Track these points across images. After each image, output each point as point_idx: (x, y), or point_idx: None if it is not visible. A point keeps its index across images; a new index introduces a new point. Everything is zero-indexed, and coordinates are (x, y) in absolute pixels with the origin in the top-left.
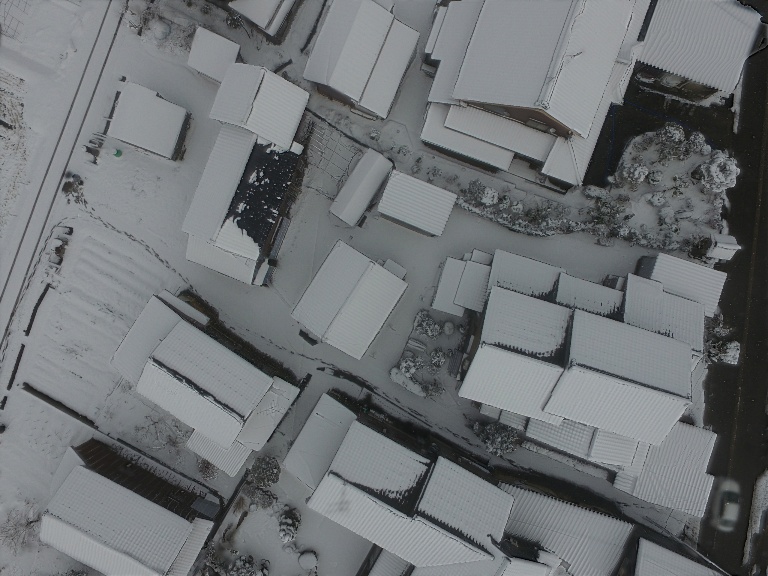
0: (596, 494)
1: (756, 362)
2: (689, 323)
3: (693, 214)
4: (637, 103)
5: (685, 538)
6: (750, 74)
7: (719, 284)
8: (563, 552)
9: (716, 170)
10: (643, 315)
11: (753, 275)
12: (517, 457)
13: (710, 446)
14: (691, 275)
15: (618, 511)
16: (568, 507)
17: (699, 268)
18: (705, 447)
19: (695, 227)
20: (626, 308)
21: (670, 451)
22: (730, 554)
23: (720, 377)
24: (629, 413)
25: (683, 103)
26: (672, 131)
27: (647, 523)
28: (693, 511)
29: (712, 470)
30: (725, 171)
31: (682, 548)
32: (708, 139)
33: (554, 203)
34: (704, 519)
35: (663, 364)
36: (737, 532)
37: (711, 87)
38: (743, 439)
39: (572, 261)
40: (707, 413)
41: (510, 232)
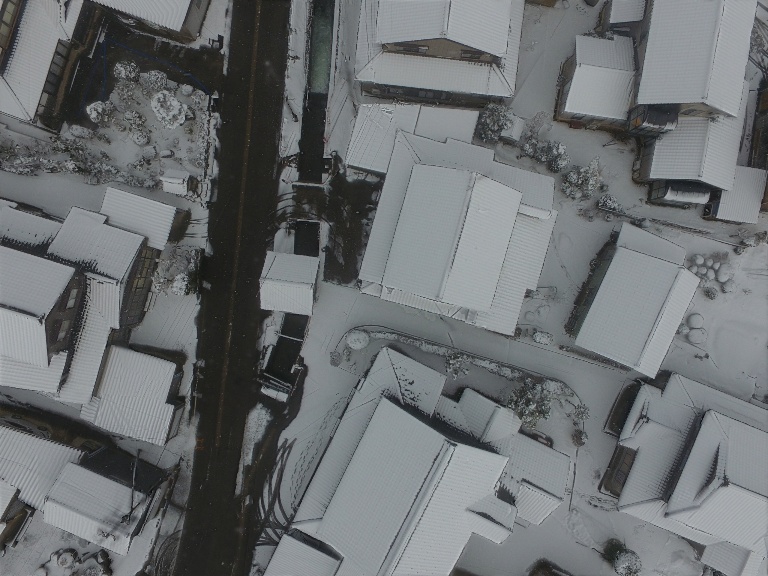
0: (92, 428)
1: (246, 298)
2: (119, 253)
3: (179, 153)
4: (127, 45)
5: (180, 470)
6: (238, 17)
7: (168, 218)
8: (12, 479)
9: (157, 105)
10: (71, 245)
11: (242, 214)
12: (14, 393)
13: (169, 377)
14: (139, 209)
15: (113, 444)
16: (17, 435)
17: (147, 202)
18: (165, 378)
19: (180, 166)
20: (55, 239)
21: (131, 382)
22: (223, 485)
23: (211, 313)
24: (3, 334)
25: (173, 45)
26: (119, 68)
27: (140, 456)
28: (154, 440)
29: (204, 404)
30: (168, 107)
31: (128, 474)
32: (199, 81)
33: (43, 143)
34: (198, 452)
35: (32, 286)
36: (229, 464)
37: (160, 25)
38: (235, 373)
39: (62, 200)
40: (200, 348)
41: (1, 172)
